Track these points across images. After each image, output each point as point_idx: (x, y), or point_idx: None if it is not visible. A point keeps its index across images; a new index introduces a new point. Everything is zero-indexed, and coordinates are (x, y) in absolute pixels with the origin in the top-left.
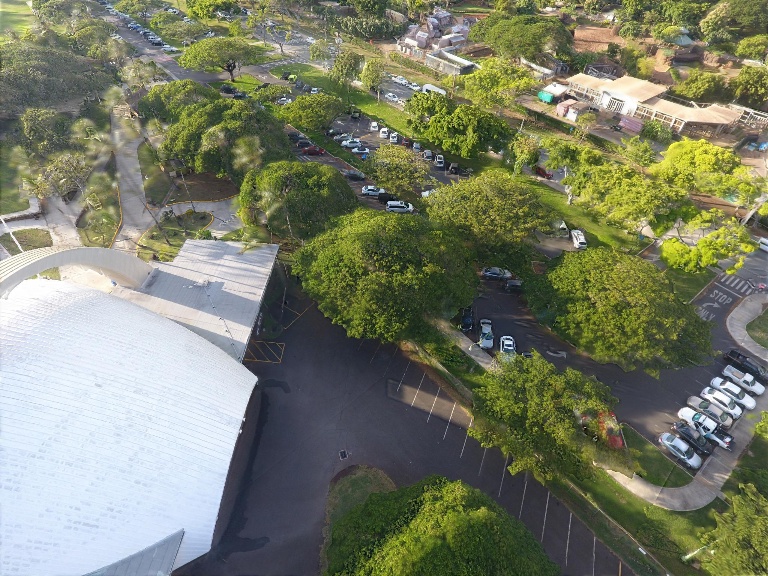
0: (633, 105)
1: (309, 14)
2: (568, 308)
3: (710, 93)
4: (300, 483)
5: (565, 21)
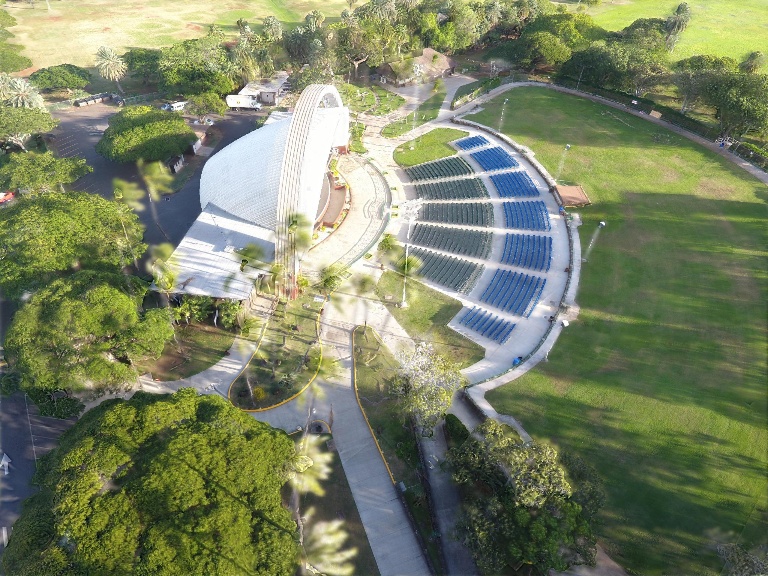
0: None
1: None
2: None
3: None
4: None
5: None
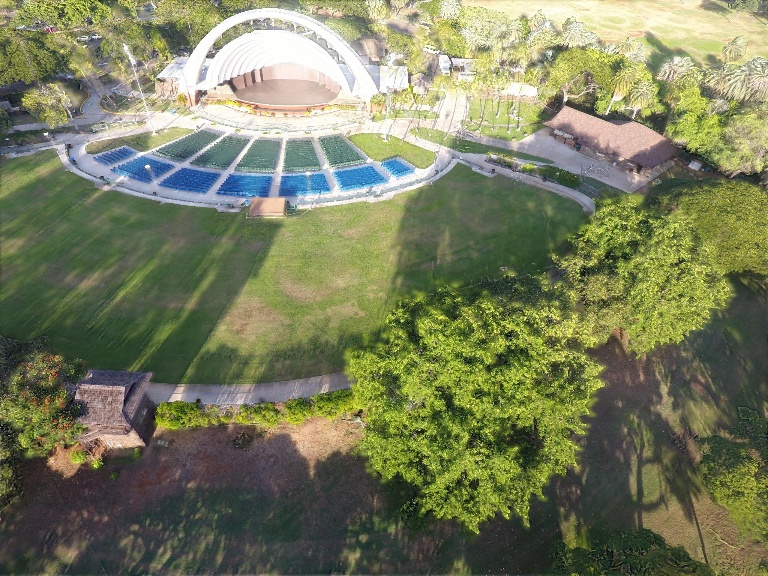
0: None
1: None
2: None
3: None
4: None
5: None
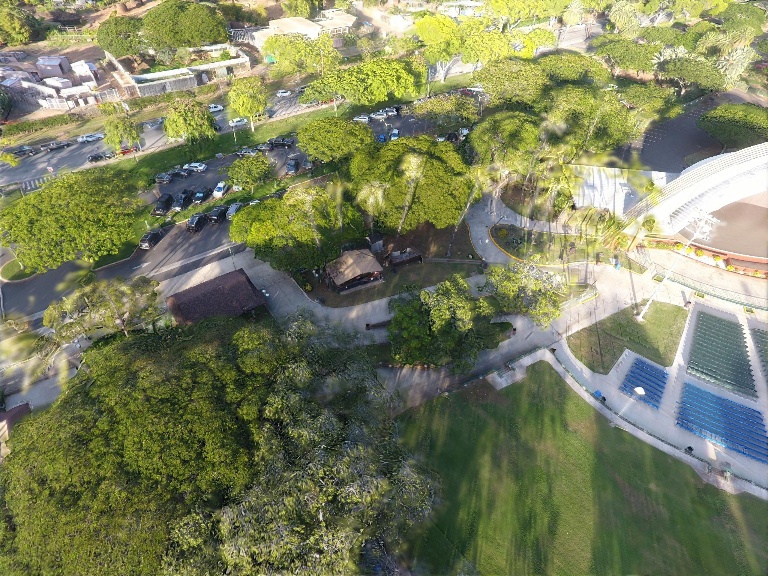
0: (315, 33)
1: None
2: (591, 79)
3: (310, 10)
4: None
5: (60, 19)
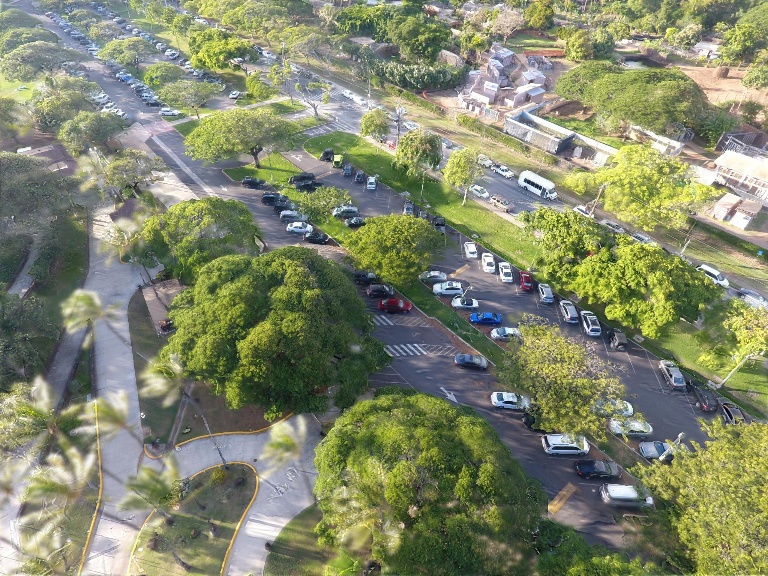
0: None
1: (338, 54)
2: None
3: None
4: None
5: (650, 58)
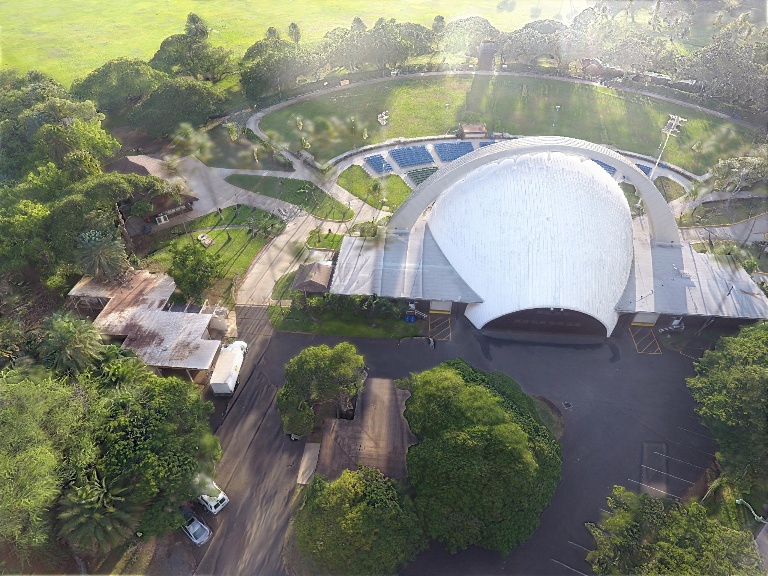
0: None
1: None
2: None
3: None
4: (535, 376)
5: None
